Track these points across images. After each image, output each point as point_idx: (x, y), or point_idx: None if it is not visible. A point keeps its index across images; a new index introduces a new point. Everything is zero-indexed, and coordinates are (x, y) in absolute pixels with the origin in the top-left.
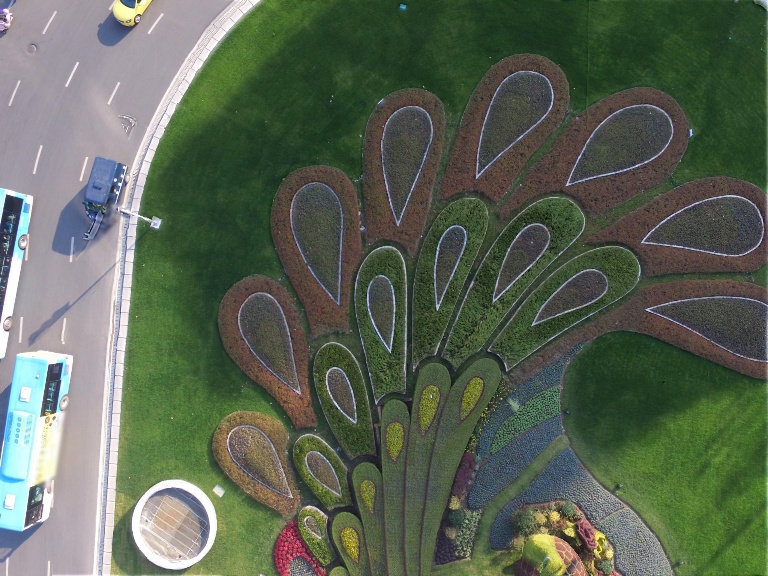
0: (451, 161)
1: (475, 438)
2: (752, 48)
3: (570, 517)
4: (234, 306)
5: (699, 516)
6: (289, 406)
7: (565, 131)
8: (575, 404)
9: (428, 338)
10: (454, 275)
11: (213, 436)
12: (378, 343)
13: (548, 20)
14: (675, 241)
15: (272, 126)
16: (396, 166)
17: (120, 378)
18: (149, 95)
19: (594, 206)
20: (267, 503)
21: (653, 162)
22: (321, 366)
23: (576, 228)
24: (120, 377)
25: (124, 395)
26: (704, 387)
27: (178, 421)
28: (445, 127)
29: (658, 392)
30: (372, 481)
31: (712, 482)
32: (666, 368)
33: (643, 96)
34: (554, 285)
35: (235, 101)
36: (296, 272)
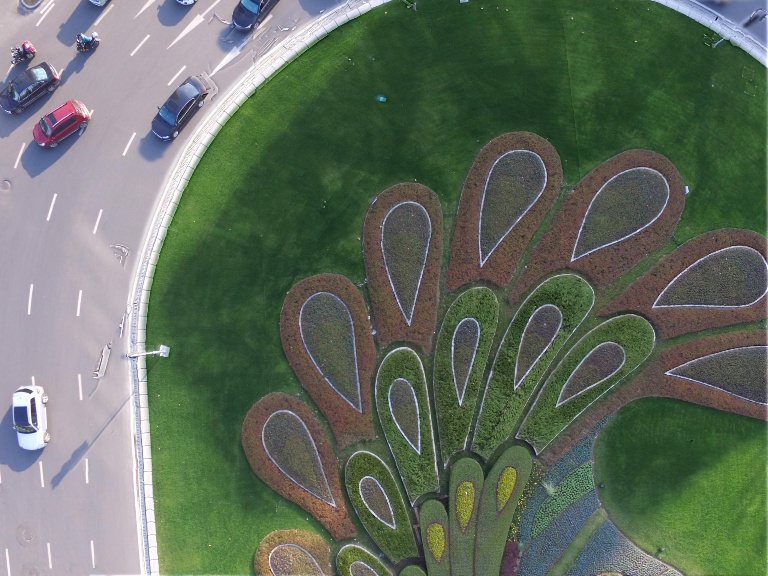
0: (454, 253)
1: (515, 527)
2: (736, 92)
3: None
4: (256, 428)
5: (742, 566)
6: (326, 520)
7: (563, 206)
8: (608, 476)
9: (455, 435)
10: (472, 368)
11: (254, 559)
12: (406, 447)
13: (530, 94)
14: (685, 301)
15: (268, 240)
16: (399, 266)
17: (151, 512)
18: (138, 221)
19: (601, 278)
20: None
21: (653, 225)
22: (352, 477)
23: (586, 303)
24: (151, 511)
25: (158, 528)
26: (731, 440)
27: (216, 548)
28: (443, 219)
29: (687, 452)
30: None
31: (750, 531)
32: (692, 427)
33: (635, 159)
34: (572, 363)
35: (227, 218)
36: (314, 386)
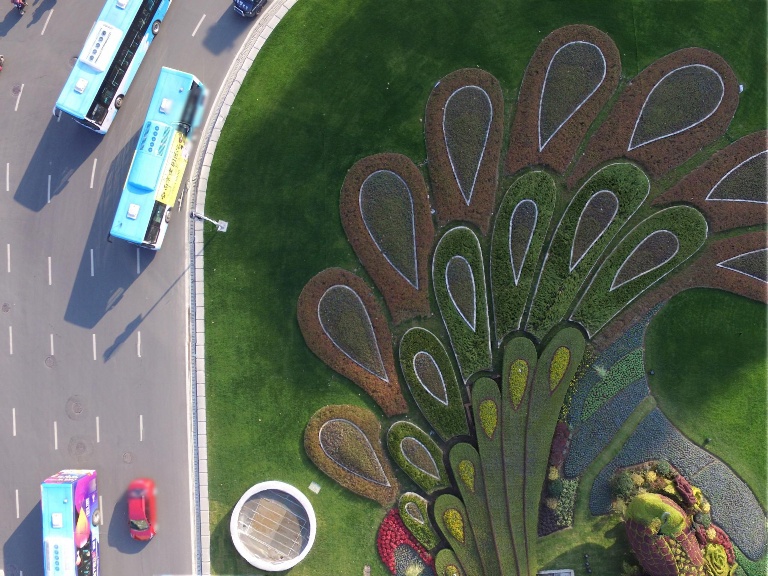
0: (514, 137)
1: (566, 407)
2: None
3: (667, 475)
4: (313, 301)
5: None
6: (378, 395)
7: (621, 97)
8: (658, 364)
9: (510, 313)
10: (529, 249)
11: (304, 433)
12: (461, 323)
13: None
14: (738, 195)
15: (331, 119)
16: (460, 147)
17: (202, 386)
18: (200, 99)
19: (657, 168)
20: (365, 494)
21: (708, 120)
22: (407, 352)
23: (642, 191)
24: (202, 385)
25: (208, 402)
26: None
27: (266, 422)
28: (503, 104)
29: (736, 344)
30: (470, 460)
31: None
32: (741, 320)
33: (692, 56)
34: (627, 249)
35: (290, 97)
36: (372, 261)
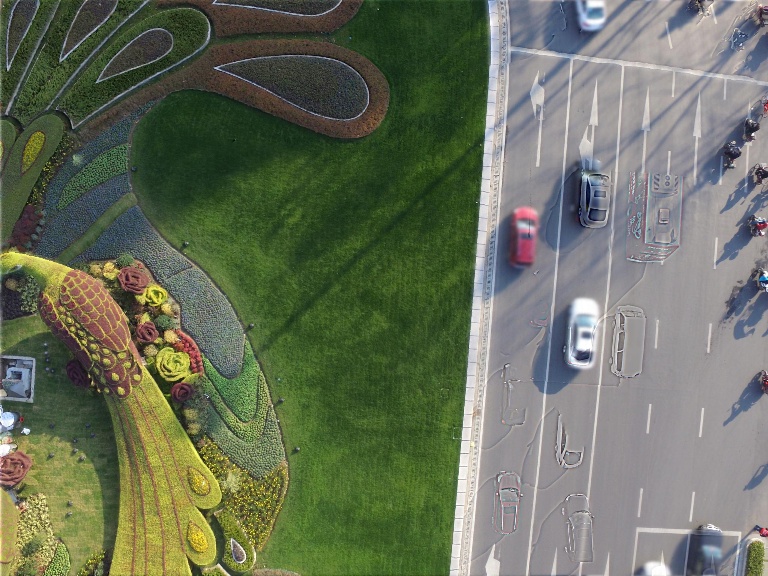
0: None
1: (36, 191)
2: None
3: (121, 266)
4: None
5: (272, 278)
6: None
7: None
8: (142, 162)
9: None
10: (24, 37)
11: None
12: None
13: None
14: (247, 1)
15: None
16: None
17: None
18: None
19: None
20: None
21: None
22: None
23: None
24: None
25: None
26: (277, 146)
27: None
28: None
29: (228, 150)
30: None
31: (286, 243)
32: (237, 127)
33: None
34: (119, 44)
35: None
36: None
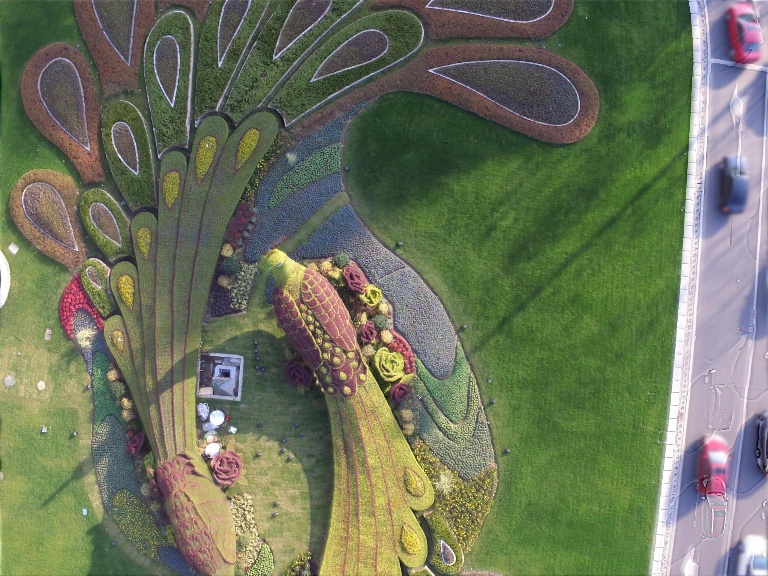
0: None
1: (250, 188)
2: None
3: (340, 265)
4: (35, 71)
5: (484, 280)
6: (78, 161)
7: None
8: (355, 161)
9: (209, 92)
10: (236, 34)
11: (10, 194)
12: (161, 98)
13: None
14: (460, 6)
15: None
16: None
17: None
18: None
19: None
20: (55, 257)
21: None
22: (107, 120)
23: None
24: None
25: None
26: (490, 149)
27: None
28: None
29: (441, 152)
30: (148, 228)
31: (498, 245)
32: (450, 129)
33: None
34: (334, 43)
35: None
36: (91, 36)
